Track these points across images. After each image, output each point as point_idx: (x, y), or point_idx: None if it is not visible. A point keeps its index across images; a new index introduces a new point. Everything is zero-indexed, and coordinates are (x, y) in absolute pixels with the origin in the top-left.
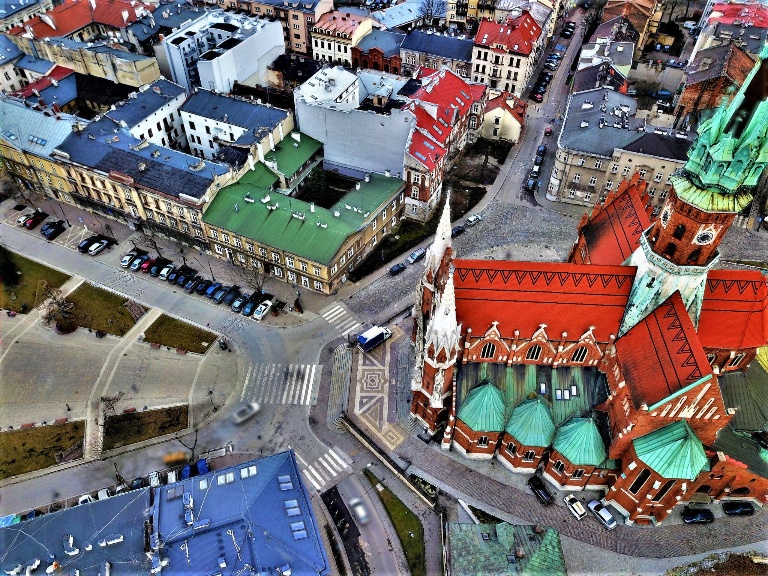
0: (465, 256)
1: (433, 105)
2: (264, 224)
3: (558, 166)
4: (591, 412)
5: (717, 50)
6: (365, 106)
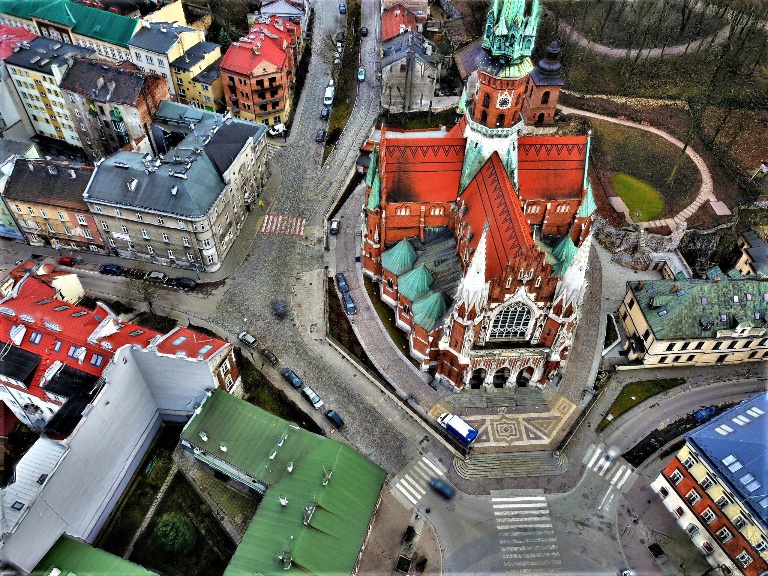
0: (309, 351)
1: (108, 321)
2: (317, 574)
3: (208, 236)
4: (545, 243)
5: (77, 71)
6: (59, 424)
